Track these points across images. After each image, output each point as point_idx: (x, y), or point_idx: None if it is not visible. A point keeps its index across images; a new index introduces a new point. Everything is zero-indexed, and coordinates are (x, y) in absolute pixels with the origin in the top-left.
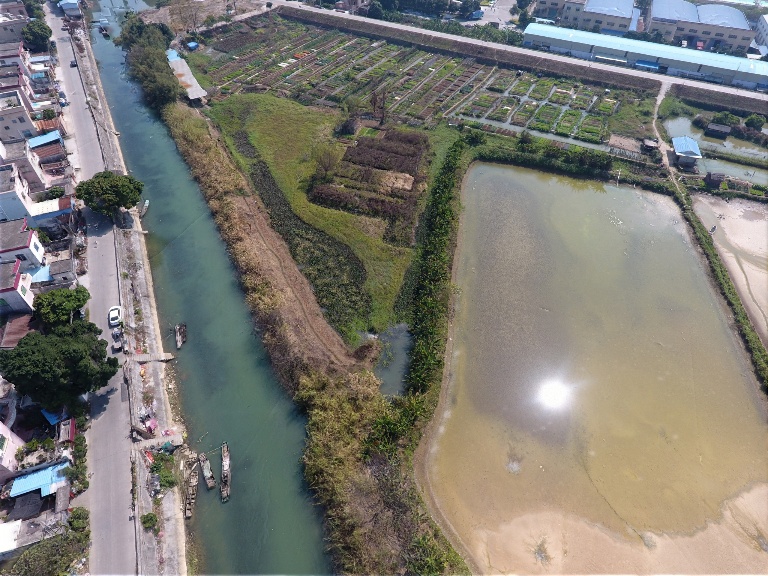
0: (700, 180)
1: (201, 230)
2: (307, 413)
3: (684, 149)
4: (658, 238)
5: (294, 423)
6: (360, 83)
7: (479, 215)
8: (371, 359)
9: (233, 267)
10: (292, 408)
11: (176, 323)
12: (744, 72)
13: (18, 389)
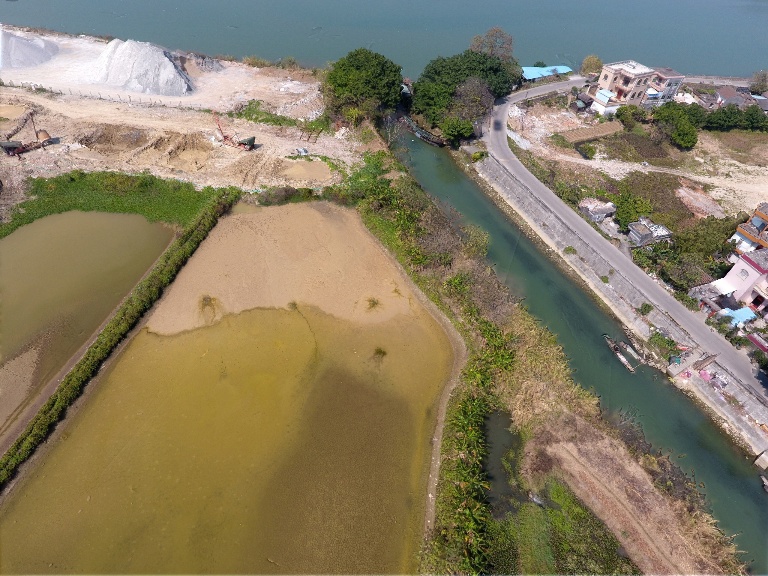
0: None
1: None
2: None
3: None
4: None
5: None
6: None
7: None
8: (529, 455)
9: None
10: None
11: None
12: None
13: None
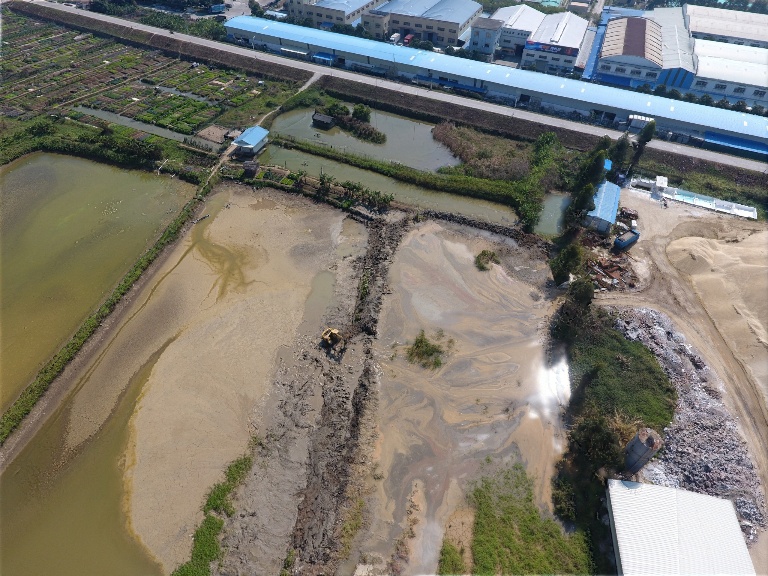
0: (242, 170)
1: None
2: None
3: (239, 139)
4: (132, 227)
5: None
6: (1, 75)
7: None
8: None
9: None
10: None
11: None
12: (401, 63)
13: None
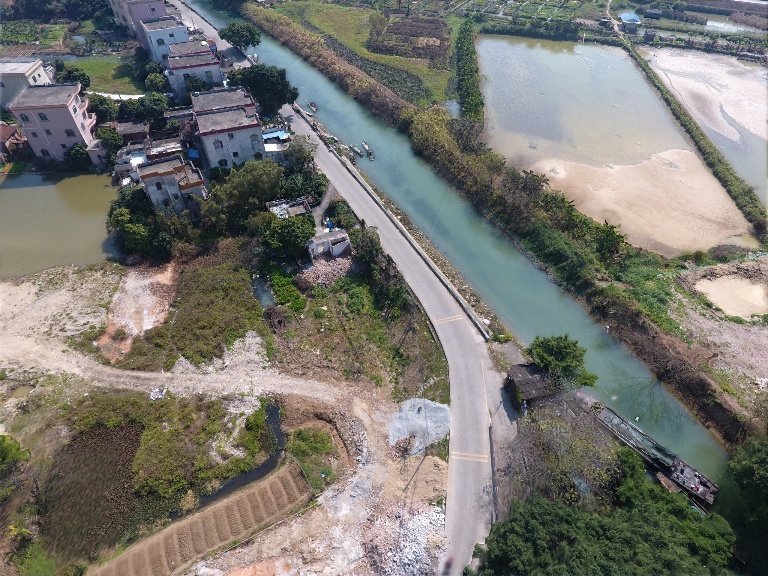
0: (640, 37)
1: (301, 67)
2: (406, 131)
3: (629, 18)
4: (612, 65)
5: (400, 136)
6: None
7: (490, 58)
8: None
9: (332, 81)
10: (396, 131)
11: (308, 102)
12: None
13: (251, 94)
